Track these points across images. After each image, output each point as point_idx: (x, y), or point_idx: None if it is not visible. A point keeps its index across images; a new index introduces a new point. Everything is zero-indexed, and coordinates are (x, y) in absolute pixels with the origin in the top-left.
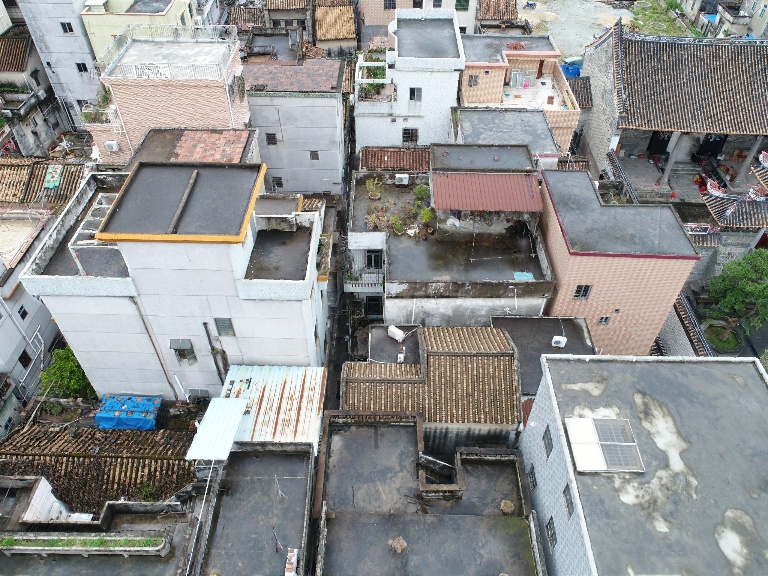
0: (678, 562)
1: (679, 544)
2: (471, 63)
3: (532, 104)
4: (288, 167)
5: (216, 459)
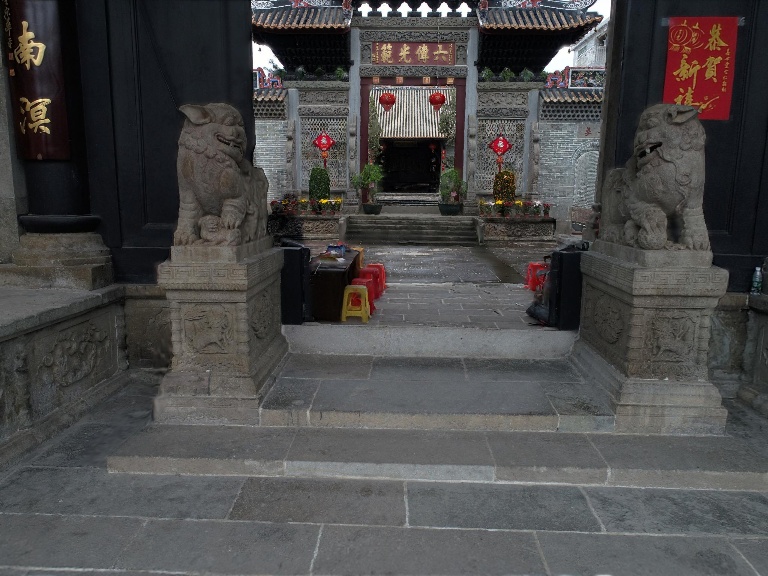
0: None
1: None
2: None
3: None
4: None
5: None
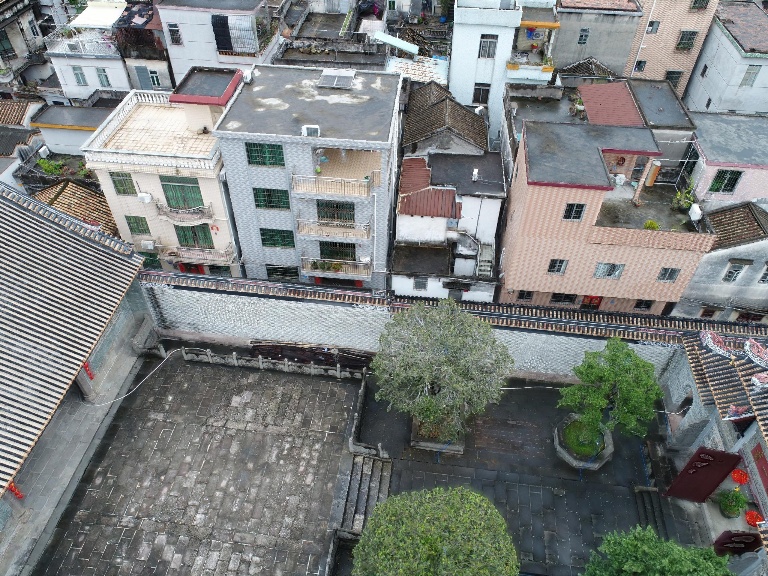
0: (270, 86)
1: (278, 88)
2: None
3: None
4: (696, 104)
5: (374, 35)
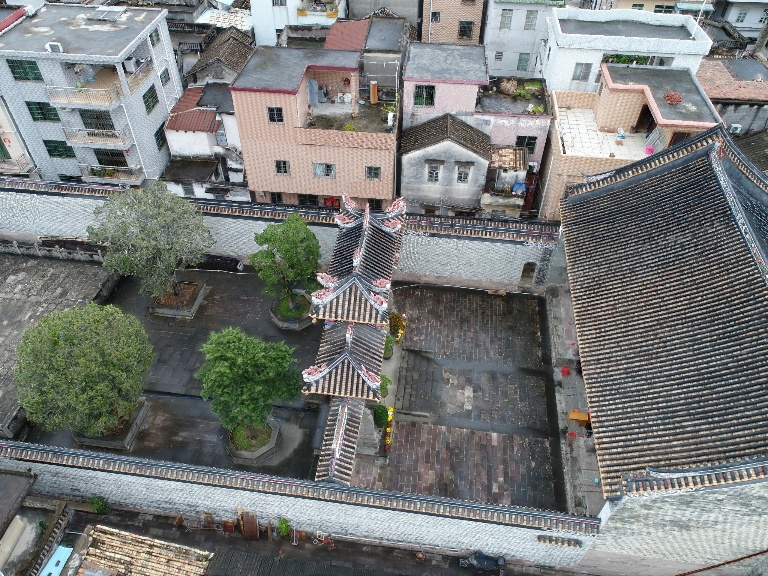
0: None
1: (54, 20)
2: (605, 67)
3: (603, 149)
4: None
5: None
